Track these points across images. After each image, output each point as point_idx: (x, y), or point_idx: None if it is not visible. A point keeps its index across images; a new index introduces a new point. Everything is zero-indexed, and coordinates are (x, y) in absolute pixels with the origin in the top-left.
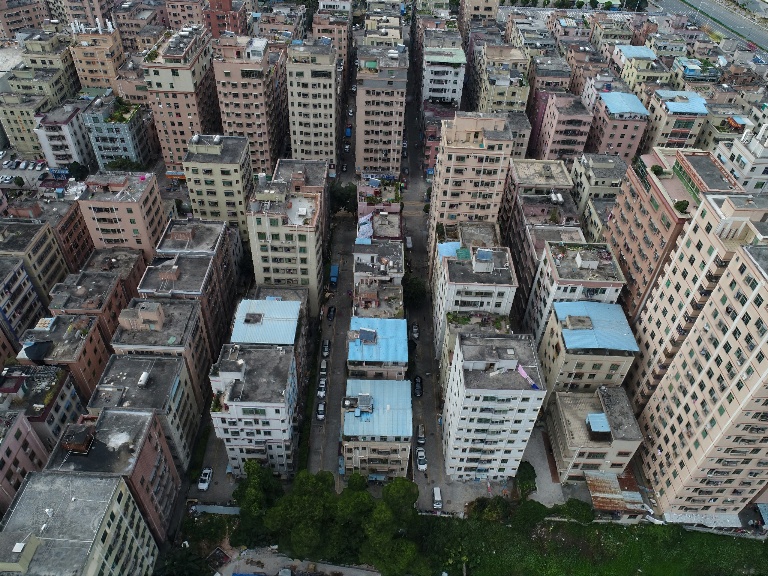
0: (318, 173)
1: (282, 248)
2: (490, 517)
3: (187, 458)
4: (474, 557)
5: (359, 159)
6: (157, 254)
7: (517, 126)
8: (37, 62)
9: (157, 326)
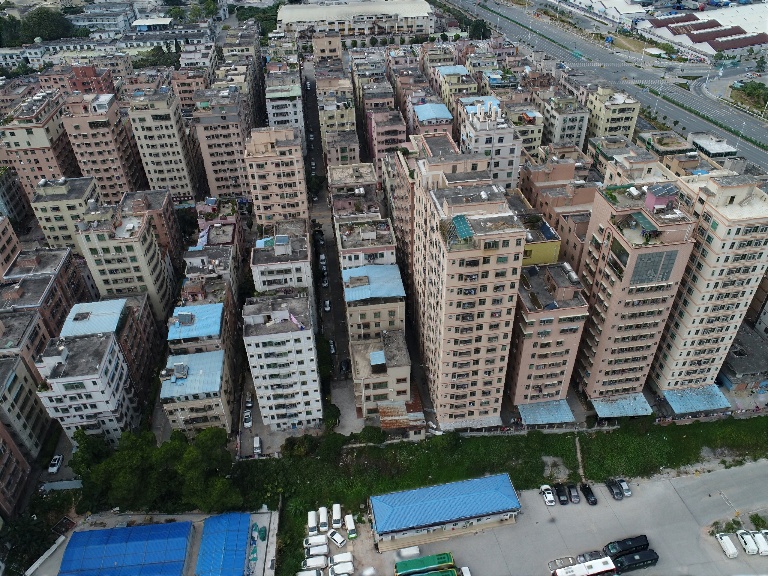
0: (160, 200)
1: (115, 260)
2: (300, 452)
3: (36, 447)
4: (289, 488)
5: (213, 188)
6: (5, 281)
7: (347, 142)
8: None
9: None
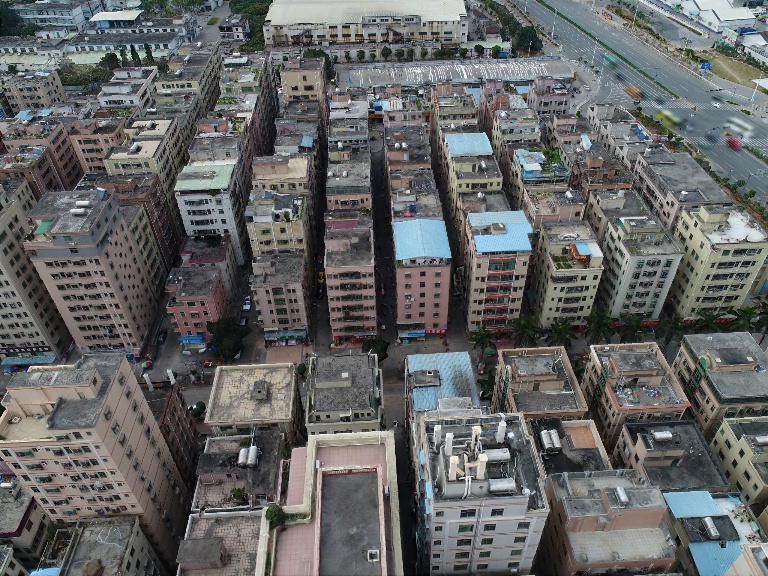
0: None
1: None
2: None
3: None
4: None
5: (78, 338)
6: None
7: (285, 277)
8: None
9: None
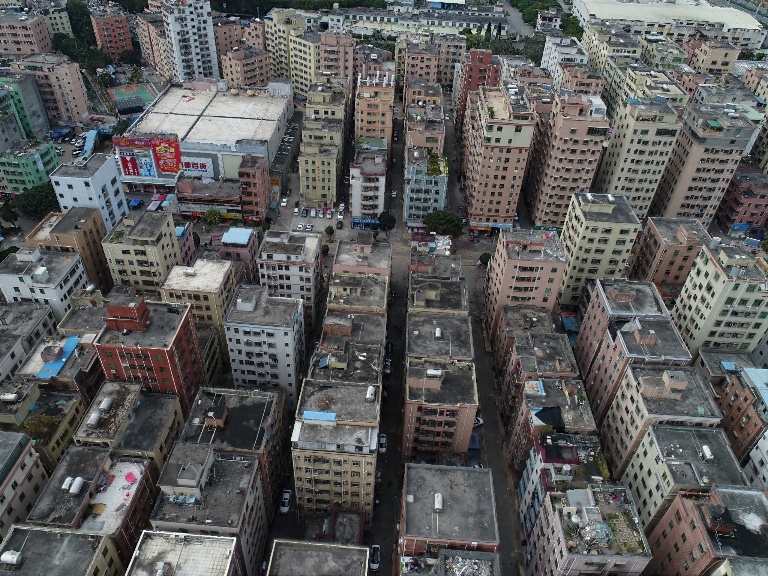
0: None
1: (743, 313)
2: None
3: None
4: None
5: (672, 214)
6: (609, 316)
7: None
8: (320, 113)
9: (679, 395)
